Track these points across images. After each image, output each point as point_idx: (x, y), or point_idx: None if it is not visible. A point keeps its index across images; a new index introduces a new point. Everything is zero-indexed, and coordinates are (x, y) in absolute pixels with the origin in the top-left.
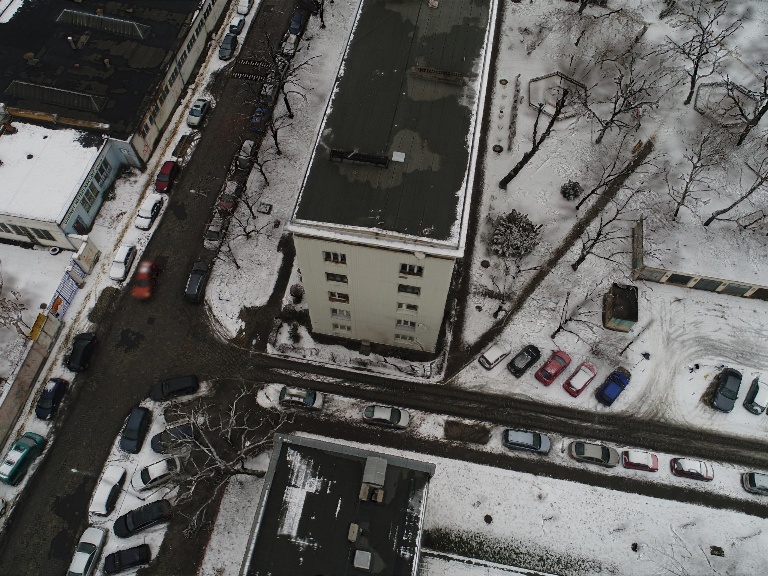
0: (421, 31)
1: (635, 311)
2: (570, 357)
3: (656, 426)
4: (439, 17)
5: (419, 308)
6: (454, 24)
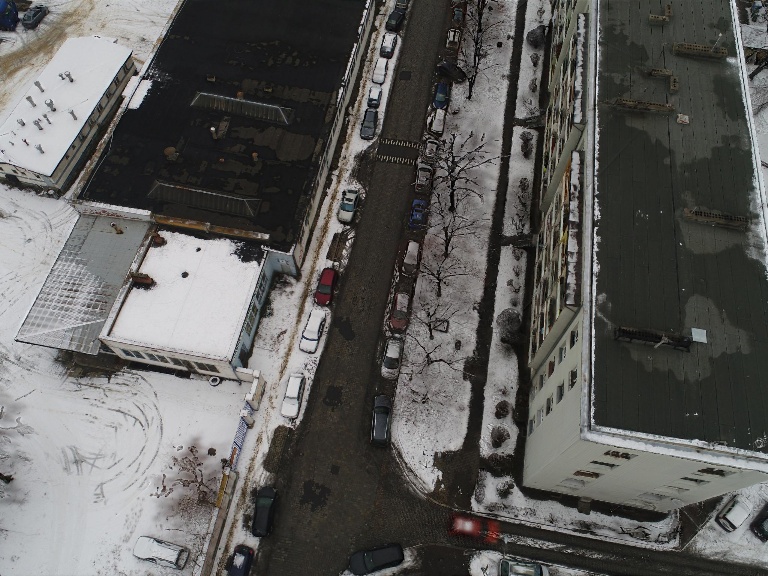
0: (678, 156)
1: None
2: None
3: None
4: (693, 136)
5: (688, 491)
6: (713, 146)
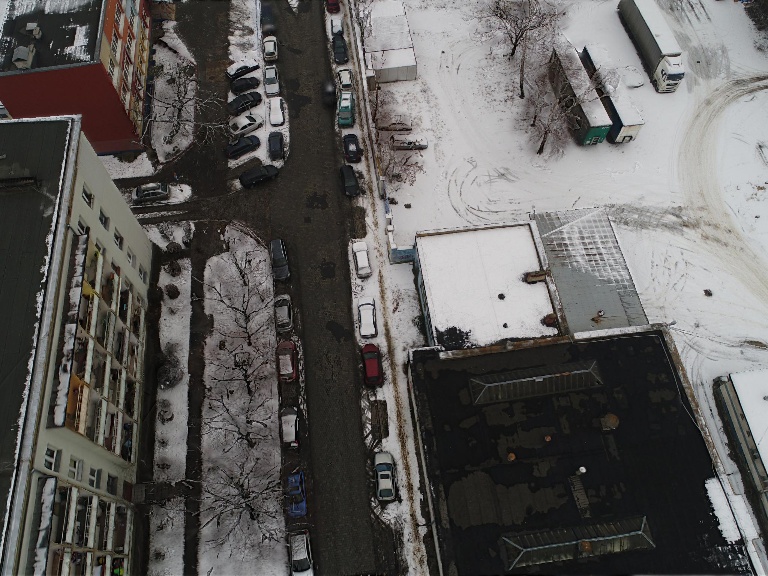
0: None
1: None
2: None
3: None
4: None
5: None
6: None
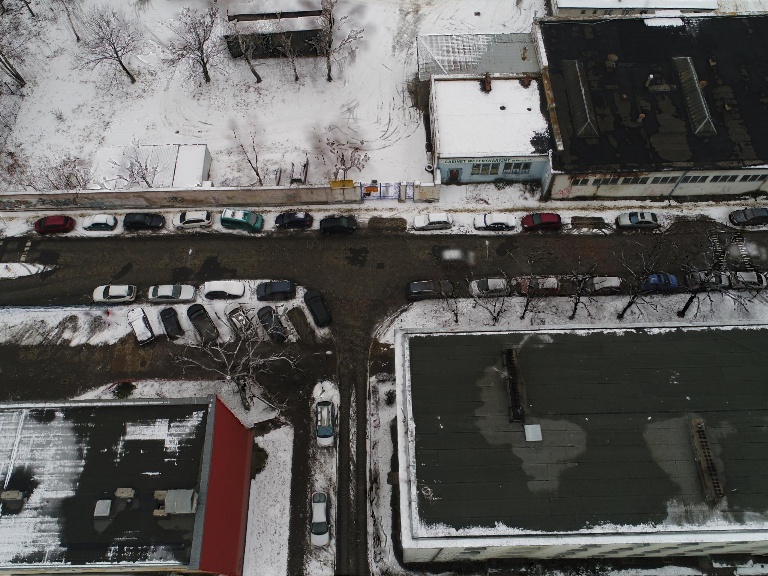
0: None
1: None
2: None
3: None
4: None
5: None
6: None
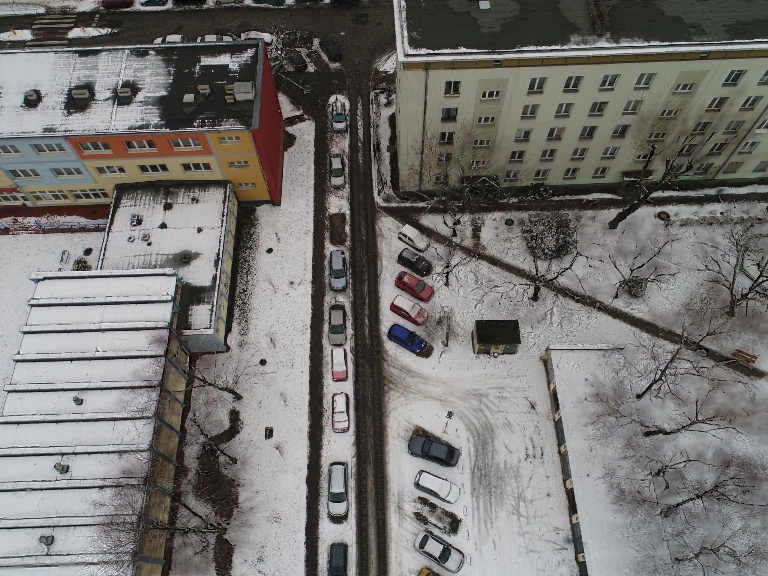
0: None
1: (489, 341)
2: (430, 302)
3: (379, 382)
4: (685, 5)
5: None
6: (682, 17)
